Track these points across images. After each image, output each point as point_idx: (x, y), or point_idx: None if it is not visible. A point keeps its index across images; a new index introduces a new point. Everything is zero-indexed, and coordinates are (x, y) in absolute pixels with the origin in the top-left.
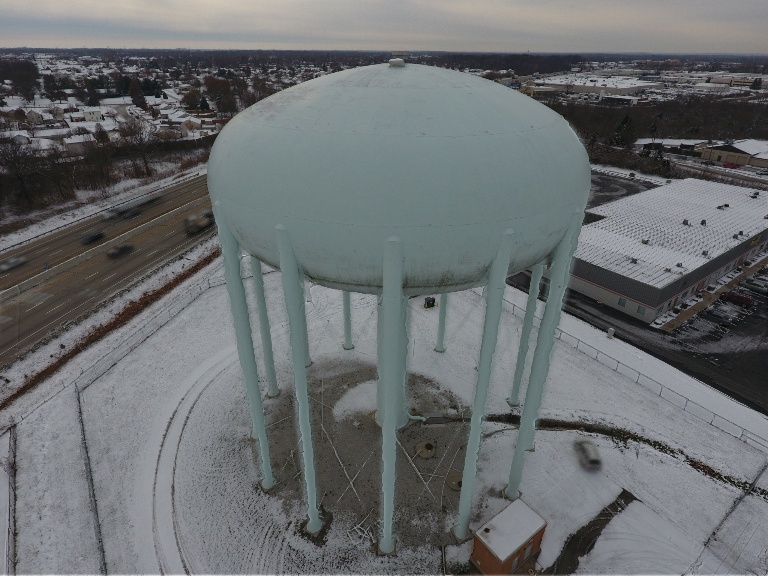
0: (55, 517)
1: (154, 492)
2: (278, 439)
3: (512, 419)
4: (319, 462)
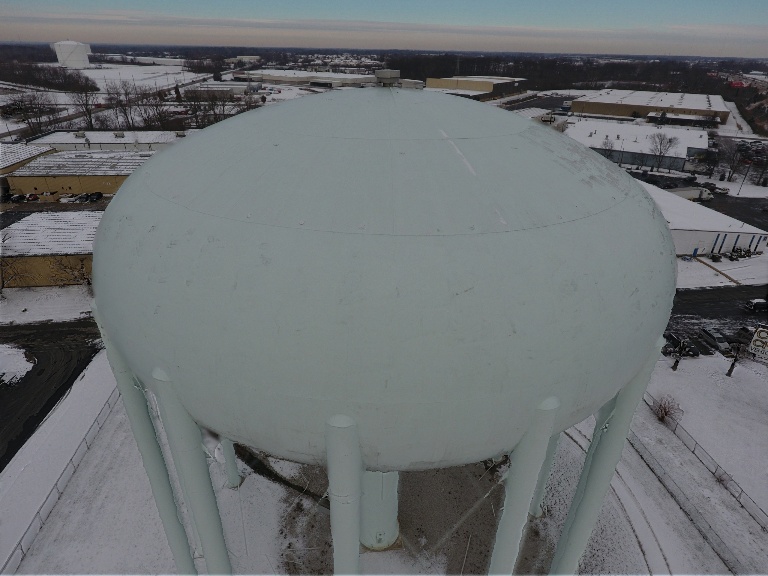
0: (765, 568)
1: (663, 553)
2: (524, 563)
3: (260, 468)
4: (480, 510)
